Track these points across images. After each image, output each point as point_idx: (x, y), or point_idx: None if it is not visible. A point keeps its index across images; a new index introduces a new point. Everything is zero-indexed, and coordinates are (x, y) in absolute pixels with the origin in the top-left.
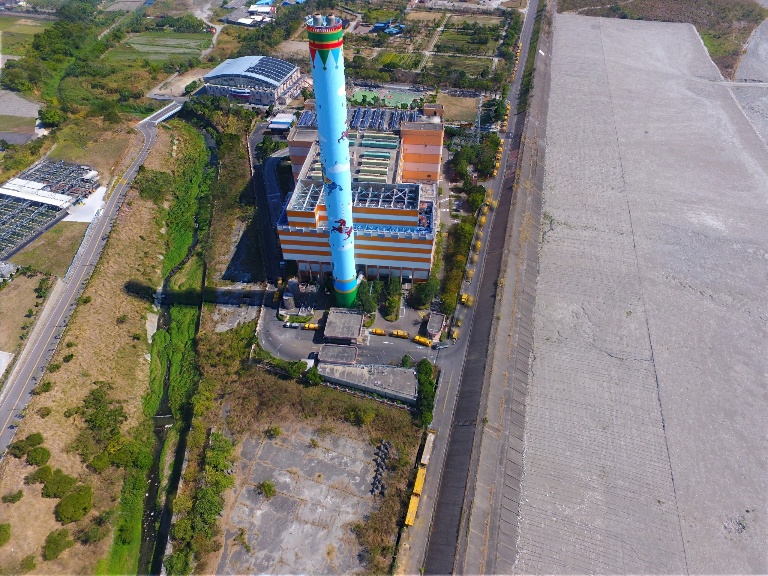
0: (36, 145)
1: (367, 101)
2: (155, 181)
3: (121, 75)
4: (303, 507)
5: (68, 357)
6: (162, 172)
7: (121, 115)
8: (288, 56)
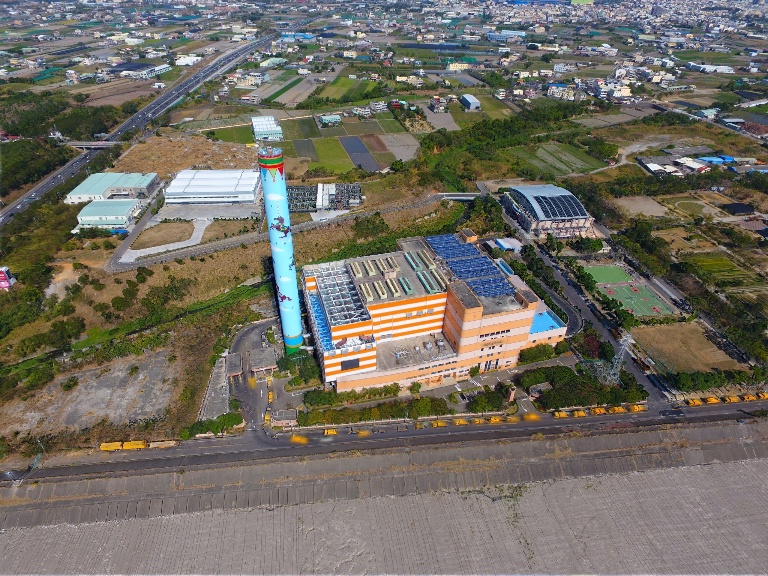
0: (365, 174)
1: (581, 273)
2: (369, 224)
3: (491, 163)
4: (121, 391)
5: (201, 259)
6: (384, 223)
7: (437, 184)
8: (612, 207)
